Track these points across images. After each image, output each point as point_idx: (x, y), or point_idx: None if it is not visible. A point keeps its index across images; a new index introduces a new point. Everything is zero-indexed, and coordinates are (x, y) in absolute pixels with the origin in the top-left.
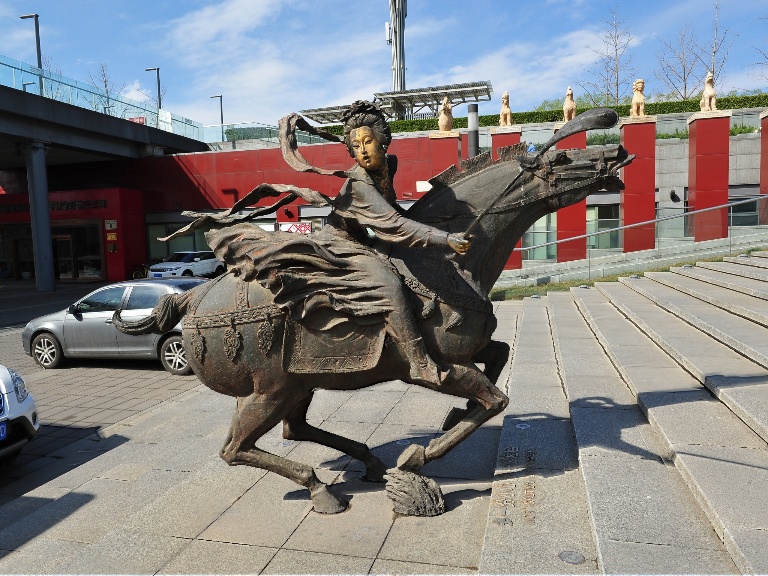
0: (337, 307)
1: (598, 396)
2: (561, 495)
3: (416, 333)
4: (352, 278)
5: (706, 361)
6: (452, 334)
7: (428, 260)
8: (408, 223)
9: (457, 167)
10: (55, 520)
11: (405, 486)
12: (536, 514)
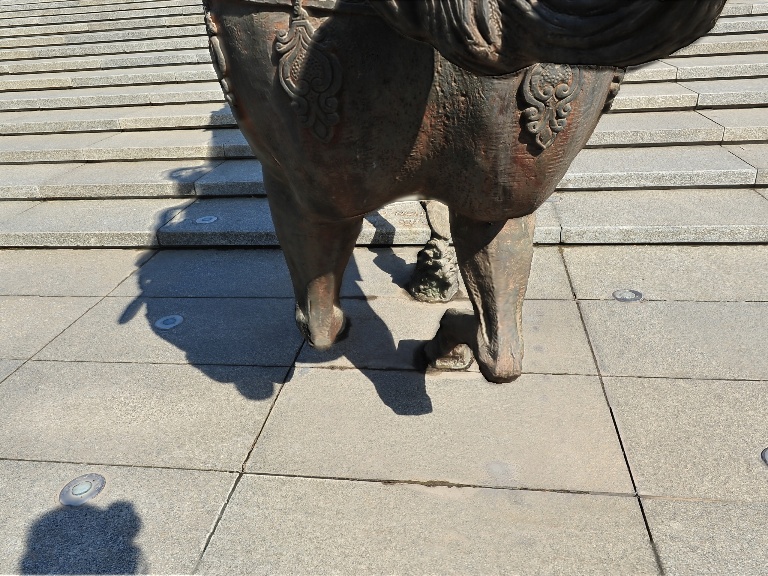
0: None
1: (161, 172)
2: None
3: None
4: None
5: (151, 113)
6: None
7: None
8: None
9: None
10: None
11: None
12: None
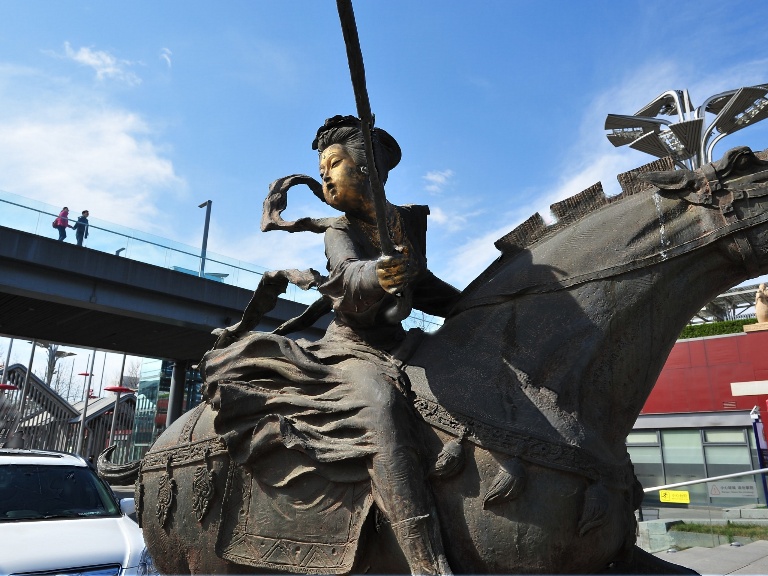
0: (291, 443)
1: None
2: None
3: (417, 504)
4: (331, 396)
5: None
6: (499, 516)
7: (469, 368)
8: (350, 265)
9: (542, 216)
10: None
11: None
12: None
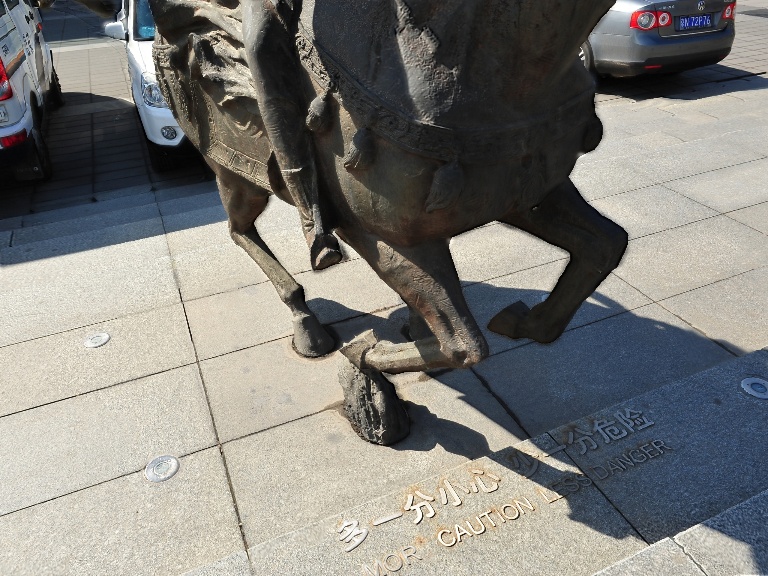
0: (207, 70)
1: None
2: (519, 573)
3: (292, 157)
4: (237, 15)
5: None
6: (358, 181)
7: None
8: None
9: None
10: (219, 219)
11: (346, 379)
12: (411, 567)
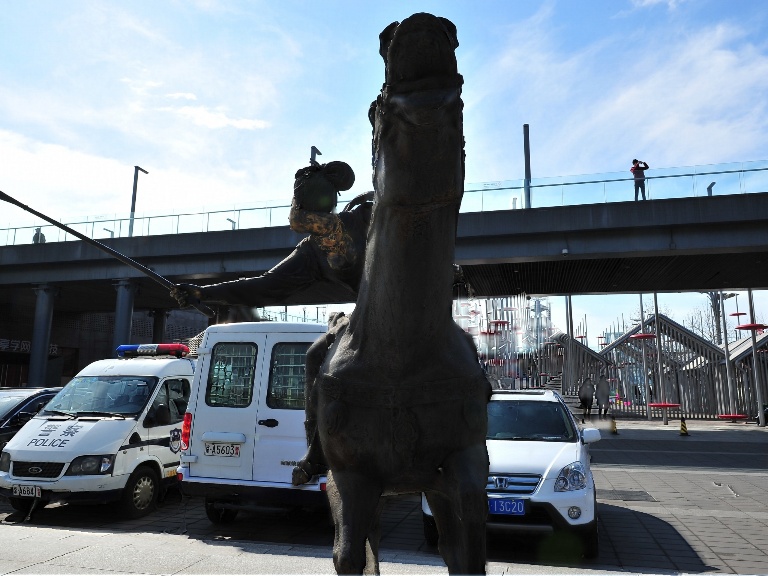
0: None
1: None
2: None
3: (308, 414)
4: None
5: None
6: None
7: None
8: None
9: None
10: None
11: None
12: None
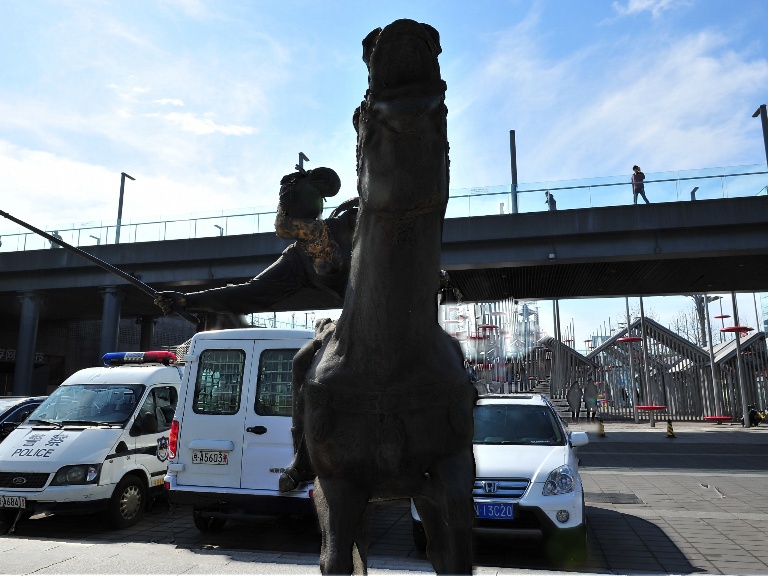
0: None
1: None
2: None
3: (295, 420)
4: None
5: None
6: None
7: None
8: None
9: None
10: None
11: None
12: None
